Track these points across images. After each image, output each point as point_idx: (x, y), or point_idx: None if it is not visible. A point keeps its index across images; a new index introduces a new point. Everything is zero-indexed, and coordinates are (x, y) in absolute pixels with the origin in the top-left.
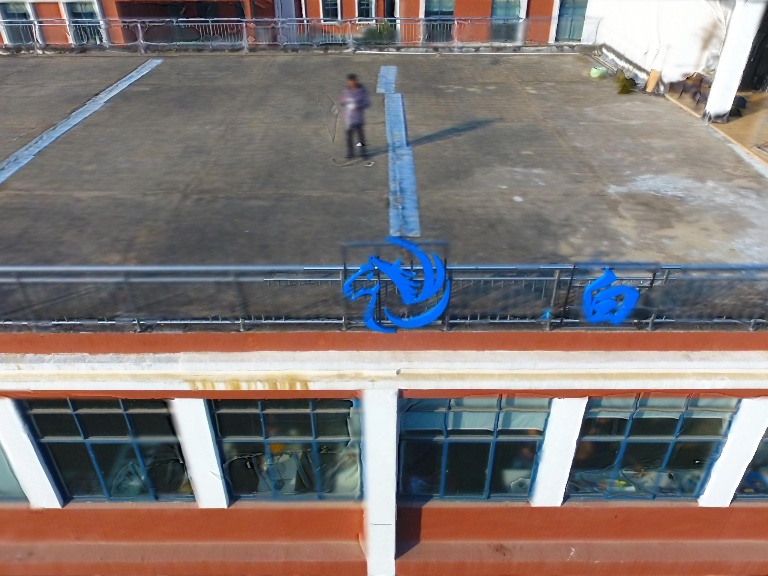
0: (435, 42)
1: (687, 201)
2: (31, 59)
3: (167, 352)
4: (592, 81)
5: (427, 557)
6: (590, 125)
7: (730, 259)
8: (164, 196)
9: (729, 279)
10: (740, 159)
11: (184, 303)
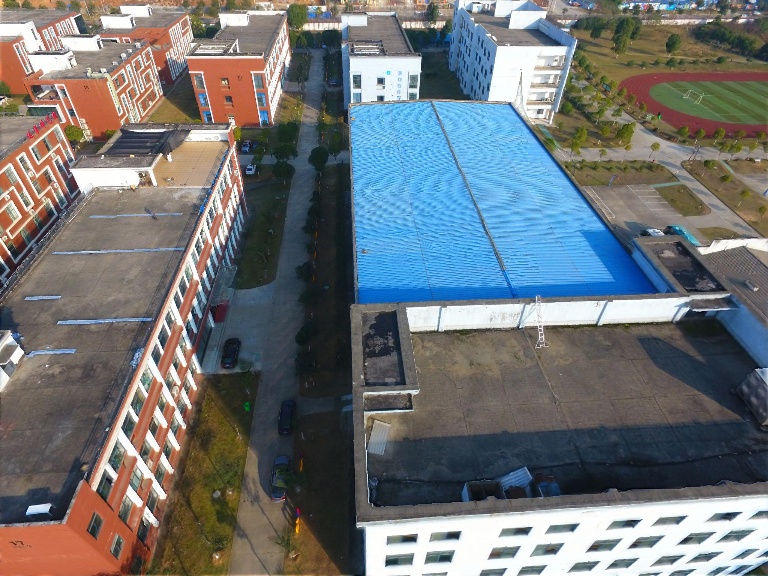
0: (75, 209)
1: None
2: (32, 277)
3: (199, 227)
4: (123, 193)
5: (212, 239)
6: (150, 197)
7: (197, 195)
8: None
9: (200, 196)
10: (172, 188)
11: (191, 226)
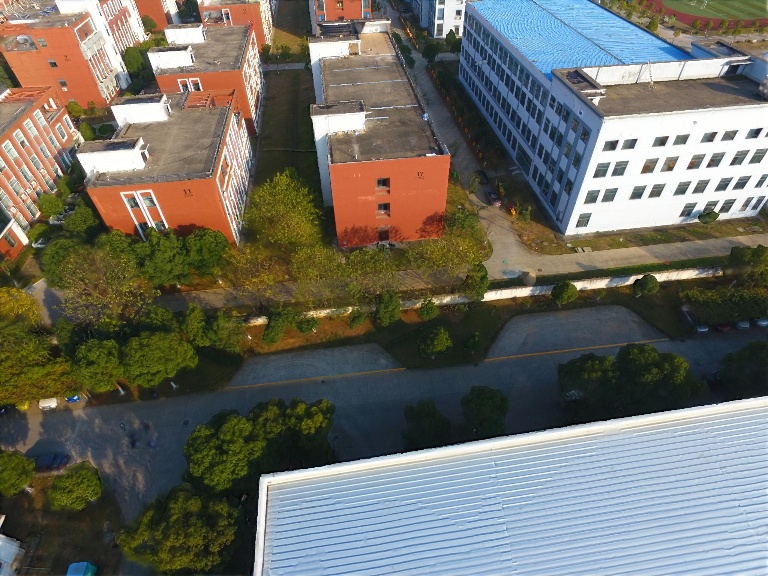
0: None
1: (381, 58)
2: None
3: None
4: None
5: None
6: (361, 60)
7: None
8: (386, 74)
9: (394, 58)
10: None
11: None
